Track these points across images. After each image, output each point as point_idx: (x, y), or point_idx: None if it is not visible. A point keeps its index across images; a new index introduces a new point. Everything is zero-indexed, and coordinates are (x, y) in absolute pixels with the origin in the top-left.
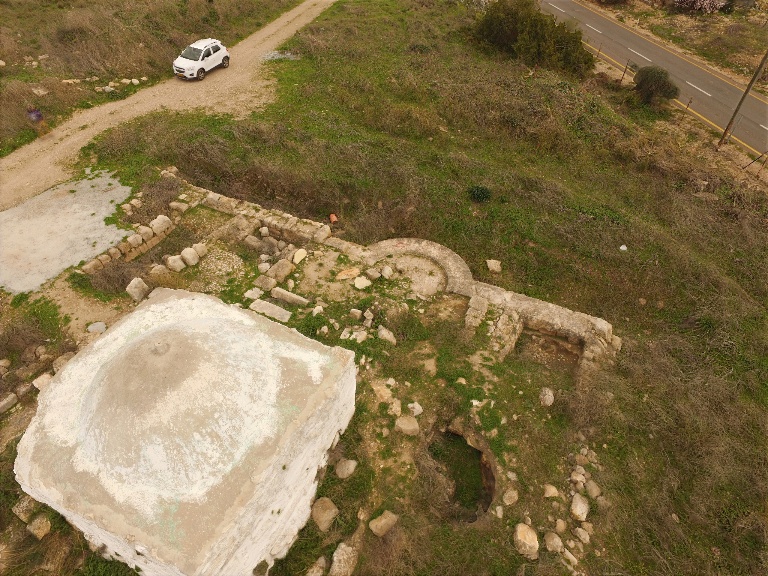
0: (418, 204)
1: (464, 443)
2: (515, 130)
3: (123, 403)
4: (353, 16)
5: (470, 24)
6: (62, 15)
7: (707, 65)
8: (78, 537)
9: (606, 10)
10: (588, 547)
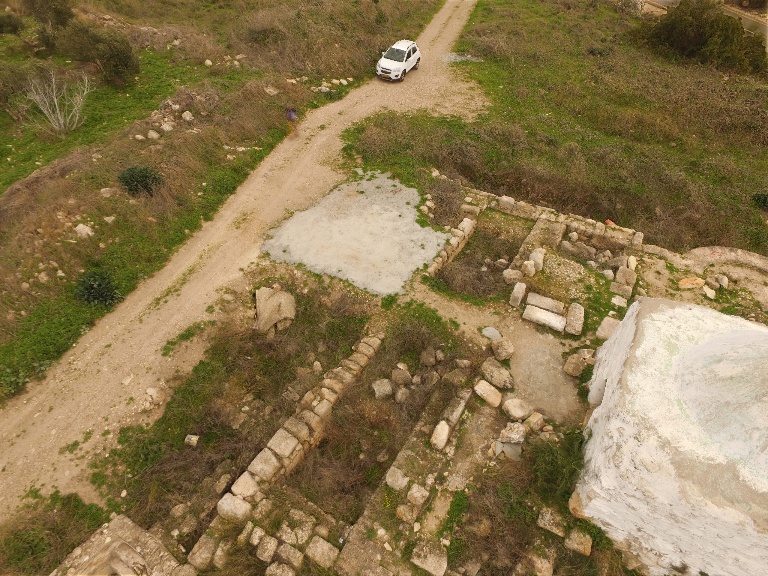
0: (707, 211)
1: None
2: (757, 136)
3: None
4: (508, 18)
5: (631, 27)
6: (254, 15)
7: None
8: (616, 553)
9: (752, 14)
10: None
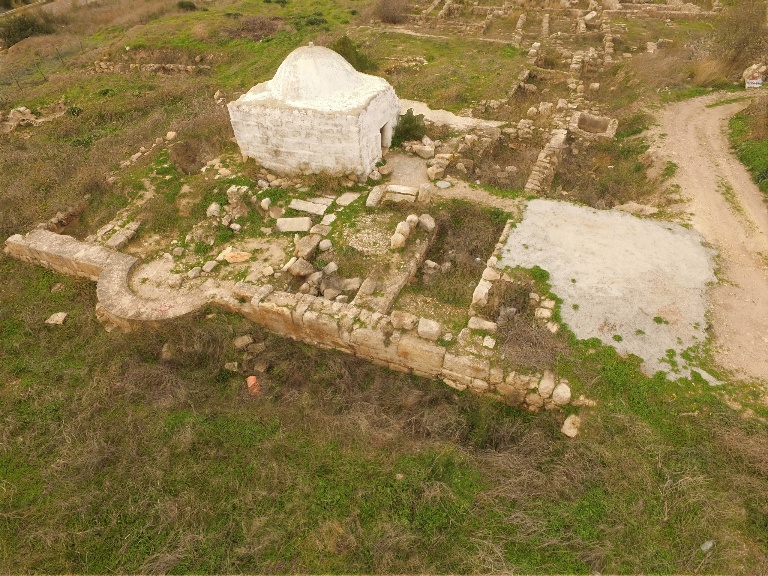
0: None
1: None
2: None
3: None
4: None
5: None
6: None
7: None
8: None
9: None
10: None
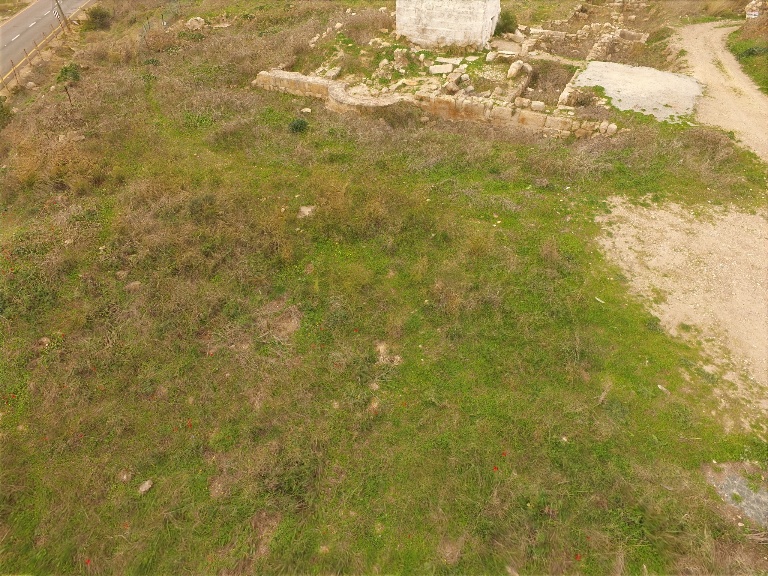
0: None
1: None
2: None
3: None
4: None
5: None
6: None
7: None
8: None
9: None
10: None
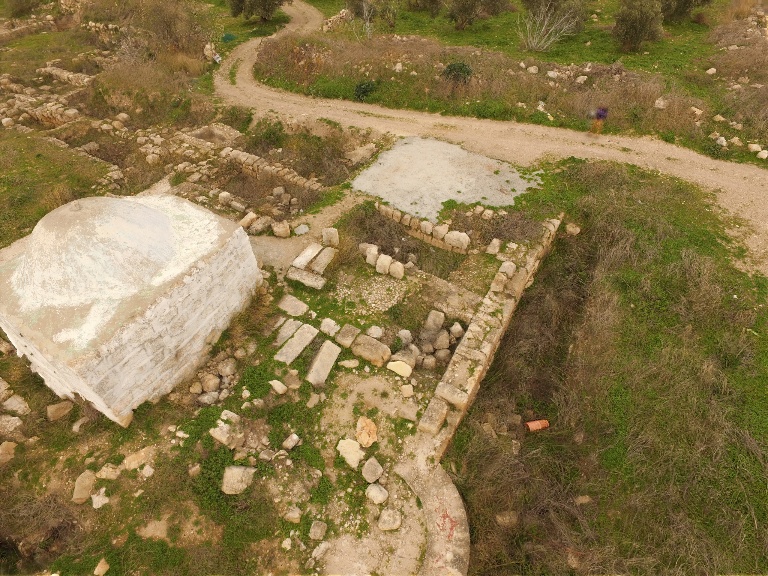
0: (582, 575)
1: None
2: None
3: None
4: None
5: None
6: None
7: None
8: None
9: None
10: None
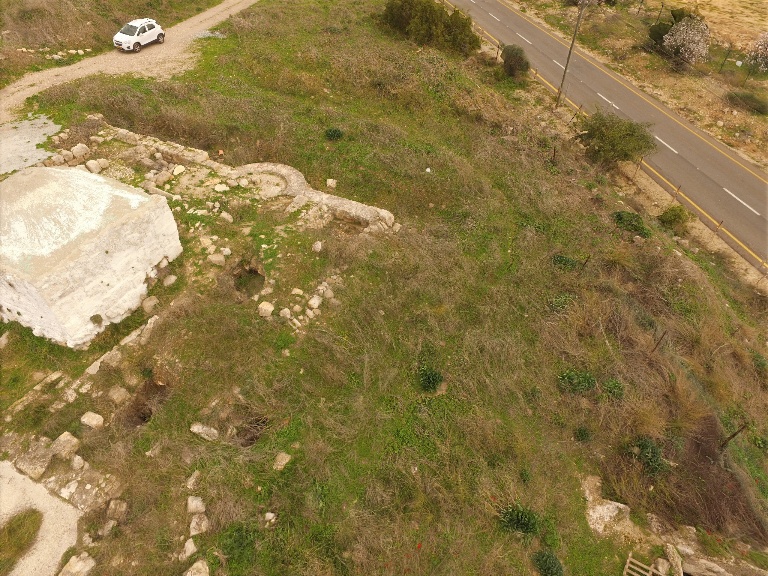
0: (284, 141)
1: (261, 277)
2: (382, 91)
3: (1, 199)
4: (284, 4)
5: None
6: None
7: (579, 47)
8: None
9: (514, 2)
10: (313, 321)
